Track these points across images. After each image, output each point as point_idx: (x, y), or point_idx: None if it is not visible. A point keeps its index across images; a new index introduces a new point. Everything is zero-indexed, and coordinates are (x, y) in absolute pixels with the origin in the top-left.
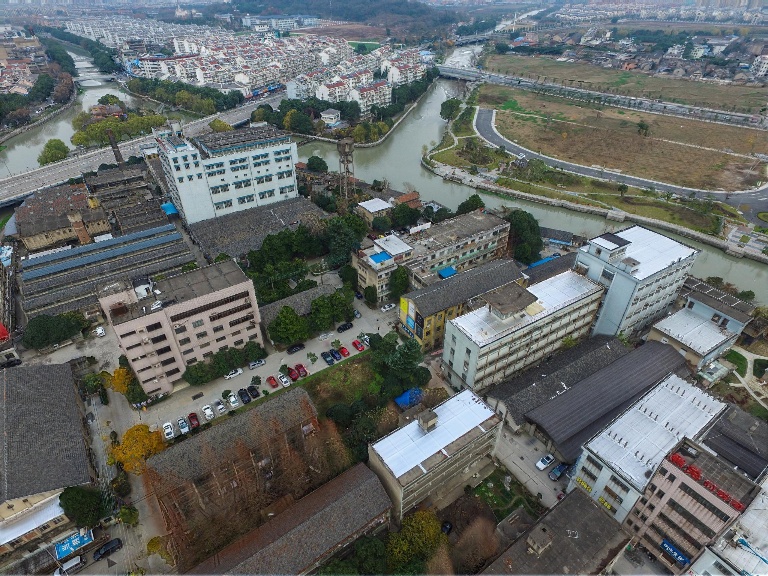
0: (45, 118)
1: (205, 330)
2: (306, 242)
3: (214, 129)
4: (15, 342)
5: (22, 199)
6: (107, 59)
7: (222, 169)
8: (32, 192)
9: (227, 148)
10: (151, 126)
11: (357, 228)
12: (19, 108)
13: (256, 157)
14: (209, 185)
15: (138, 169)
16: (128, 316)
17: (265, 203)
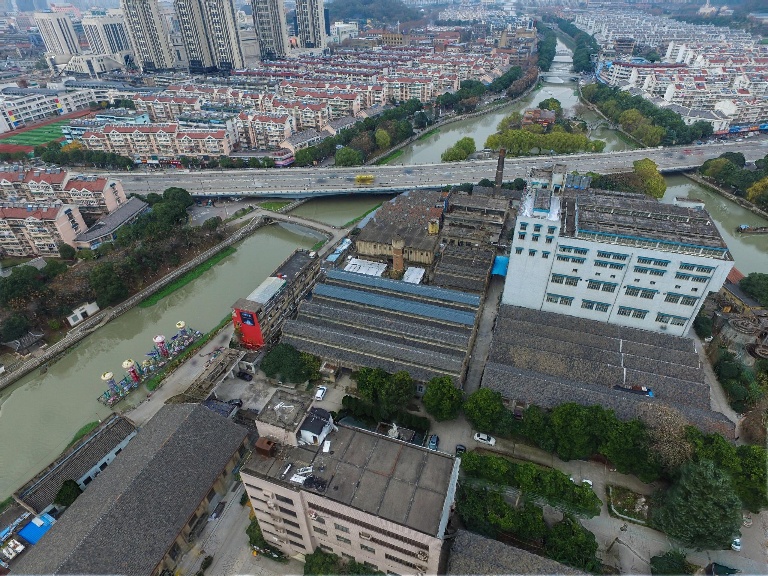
0: (488, 110)
1: (350, 538)
2: (632, 451)
3: (637, 170)
4: (259, 357)
5: (401, 191)
6: (584, 57)
7: (582, 257)
8: (411, 188)
9: (606, 232)
10: (567, 146)
11: (759, 488)
12: (471, 97)
13: (645, 259)
14: (552, 269)
15: (506, 201)
16: (266, 465)
17: (622, 322)
